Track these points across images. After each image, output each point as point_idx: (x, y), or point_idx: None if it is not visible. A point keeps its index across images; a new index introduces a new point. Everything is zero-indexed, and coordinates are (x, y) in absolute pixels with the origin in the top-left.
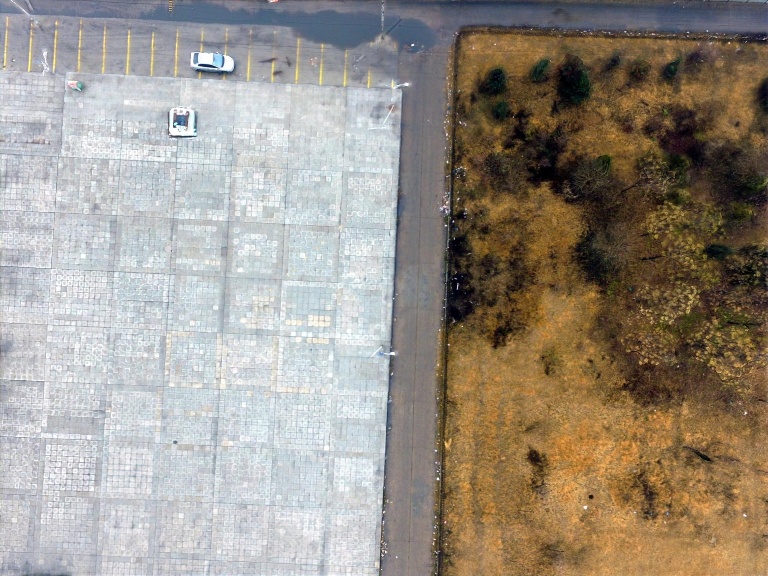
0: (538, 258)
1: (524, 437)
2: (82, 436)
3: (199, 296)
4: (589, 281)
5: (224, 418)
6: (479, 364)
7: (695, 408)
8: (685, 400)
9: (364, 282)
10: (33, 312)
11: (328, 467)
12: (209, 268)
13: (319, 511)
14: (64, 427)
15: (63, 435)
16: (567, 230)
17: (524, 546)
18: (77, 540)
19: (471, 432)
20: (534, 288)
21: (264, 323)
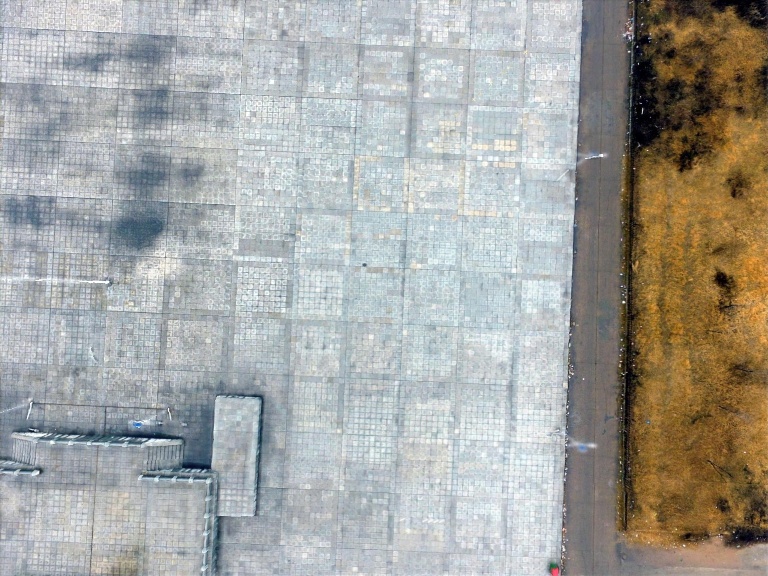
0: (724, 81)
1: (711, 259)
2: (273, 259)
3: (386, 121)
4: None
5: (412, 241)
6: (665, 187)
7: None
8: None
9: (550, 107)
10: (223, 137)
11: (515, 289)
12: (396, 93)
13: (507, 332)
14: (255, 250)
15: (254, 258)
16: (753, 53)
17: (712, 366)
18: (270, 360)
19: (658, 254)
20: (720, 112)
21: (451, 148)
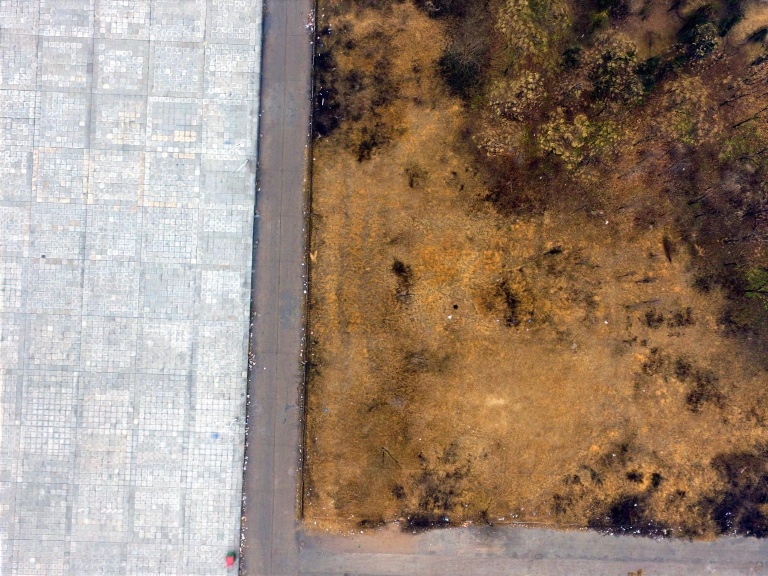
0: (402, 72)
1: (389, 248)
2: None
3: (65, 112)
4: (453, 95)
5: (91, 232)
6: (344, 178)
7: (557, 217)
8: (547, 209)
9: (229, 97)
10: None
11: (195, 280)
12: (75, 85)
13: (187, 323)
14: None
15: None
16: (431, 44)
17: (389, 354)
18: None
19: (336, 244)
20: (398, 102)
21: (130, 139)
